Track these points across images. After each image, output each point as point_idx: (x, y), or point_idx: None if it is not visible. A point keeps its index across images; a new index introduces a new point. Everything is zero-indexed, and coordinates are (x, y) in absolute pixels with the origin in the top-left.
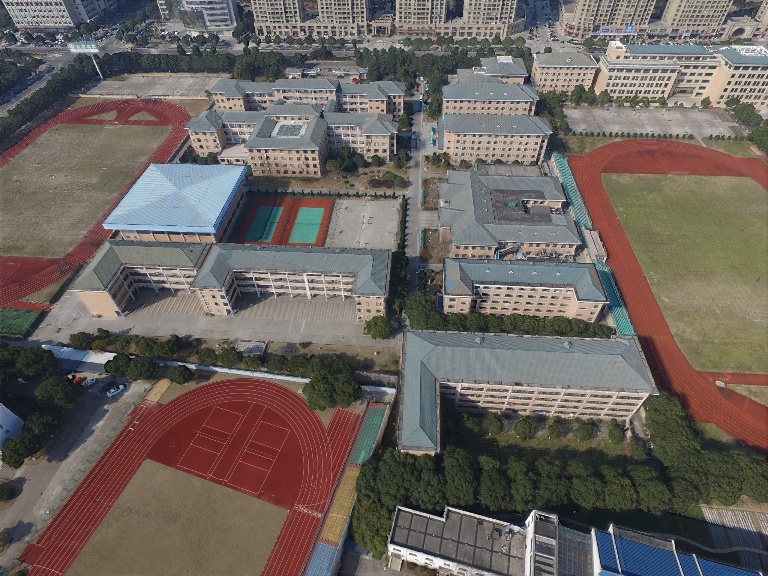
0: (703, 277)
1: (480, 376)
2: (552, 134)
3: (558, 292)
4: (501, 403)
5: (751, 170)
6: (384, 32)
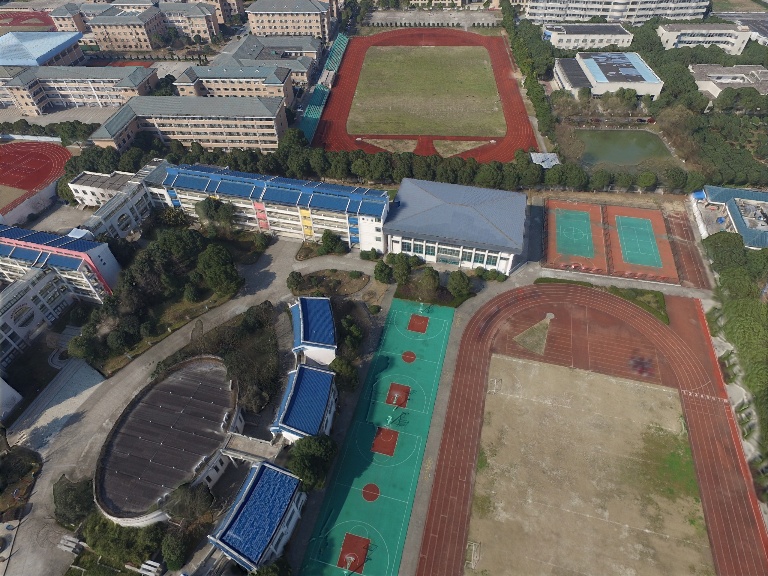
0: (396, 94)
1: (164, 112)
2: (344, 21)
3: (257, 84)
4: (192, 141)
5: (488, 42)
6: None
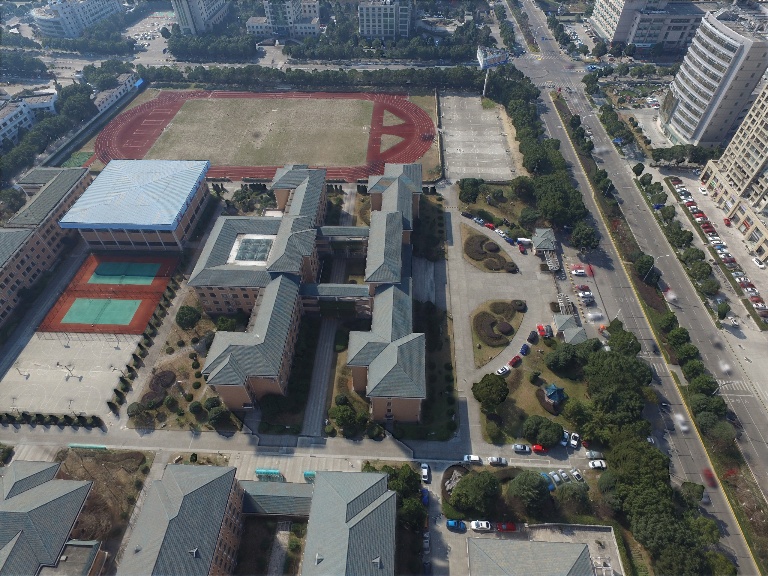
0: None
1: None
2: None
3: None
4: None
5: None
6: None
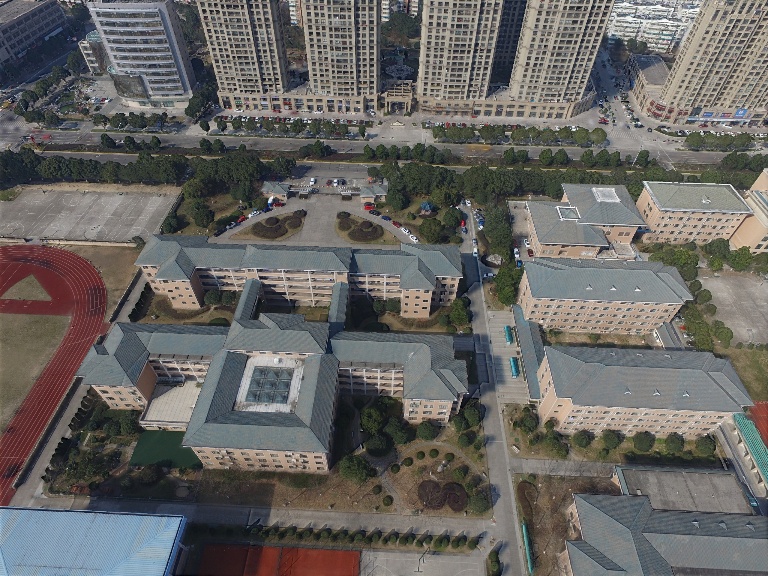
0: None
1: None
2: None
3: None
4: None
5: None
6: (400, 106)
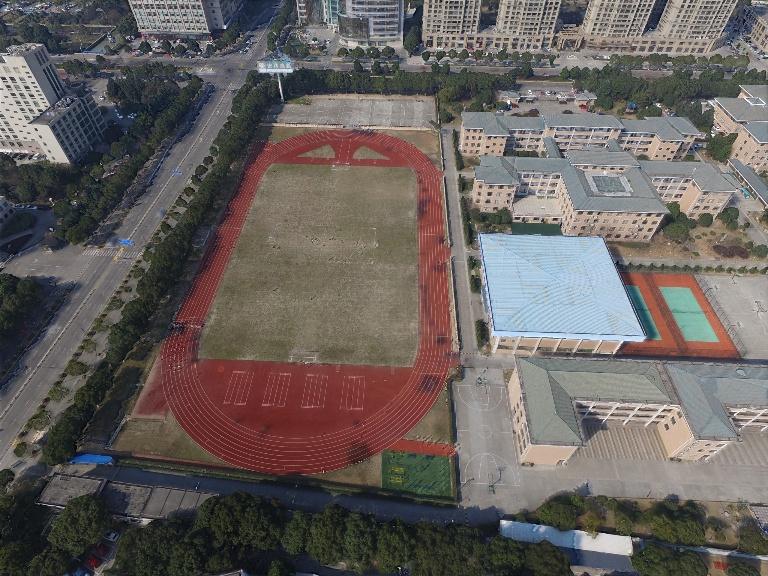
0: None
1: None
2: None
3: None
4: None
5: None
6: (568, 45)
